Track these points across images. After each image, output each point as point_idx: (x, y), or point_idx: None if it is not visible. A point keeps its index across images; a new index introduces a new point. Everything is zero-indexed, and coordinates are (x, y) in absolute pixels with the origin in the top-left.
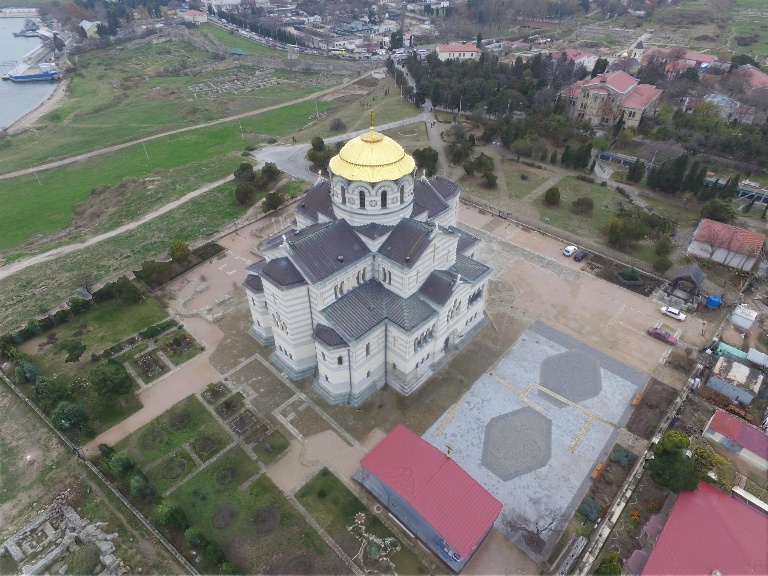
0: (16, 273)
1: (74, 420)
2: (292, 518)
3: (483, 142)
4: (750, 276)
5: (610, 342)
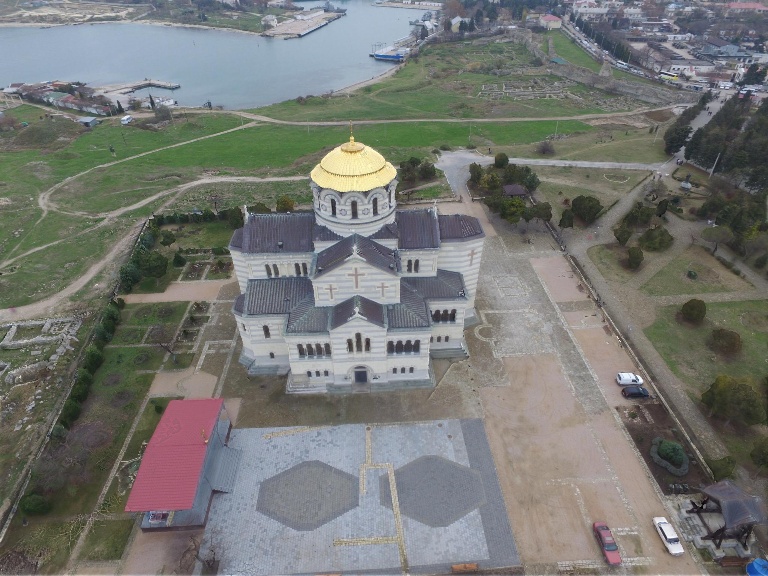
0: (212, 183)
1: (128, 278)
2: (132, 410)
3: (694, 216)
4: None
5: (530, 497)
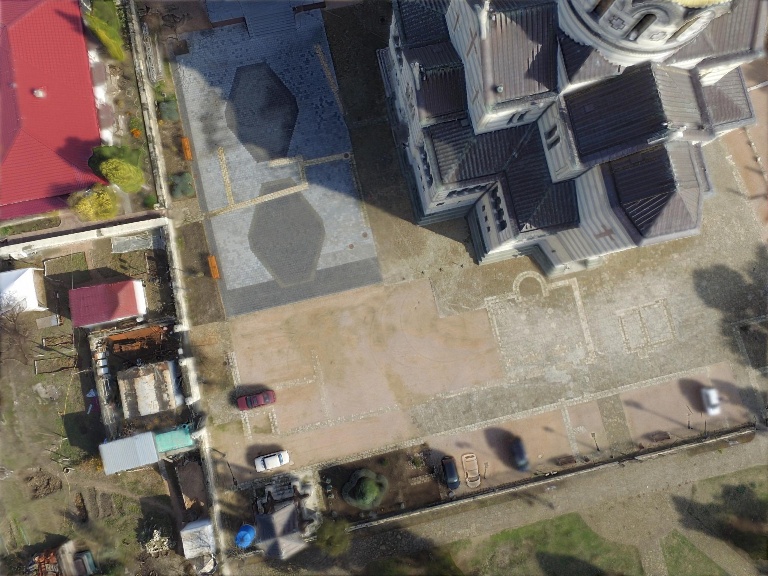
0: None
1: None
2: None
3: None
4: None
5: (294, 331)
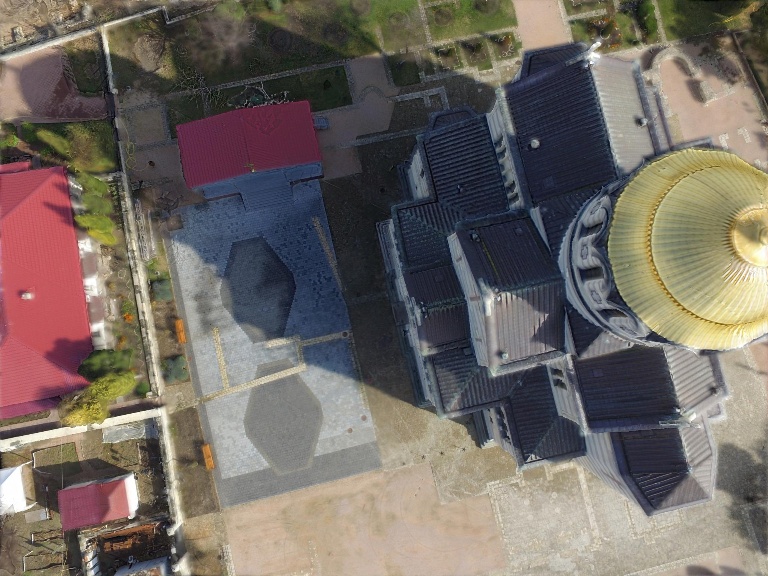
0: None
1: None
2: (324, 55)
3: None
4: None
5: (291, 522)
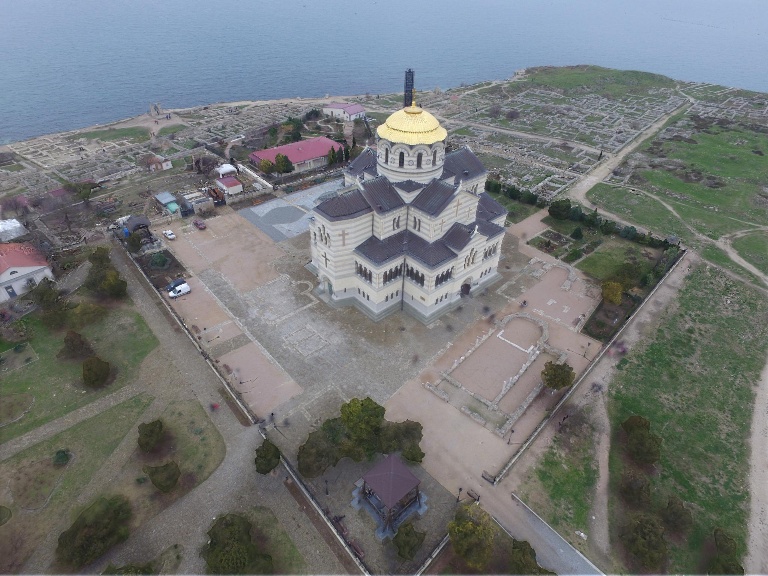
0: None
1: None
2: None
3: None
4: (50, 252)
5: (238, 227)
